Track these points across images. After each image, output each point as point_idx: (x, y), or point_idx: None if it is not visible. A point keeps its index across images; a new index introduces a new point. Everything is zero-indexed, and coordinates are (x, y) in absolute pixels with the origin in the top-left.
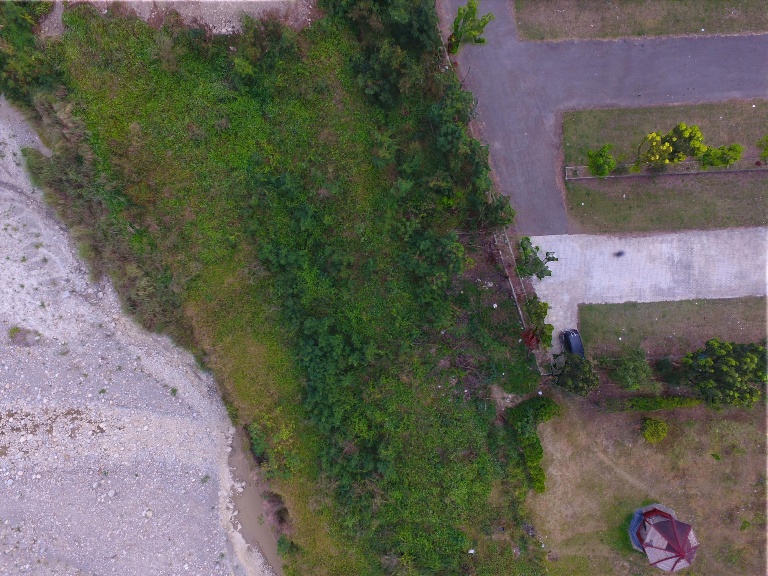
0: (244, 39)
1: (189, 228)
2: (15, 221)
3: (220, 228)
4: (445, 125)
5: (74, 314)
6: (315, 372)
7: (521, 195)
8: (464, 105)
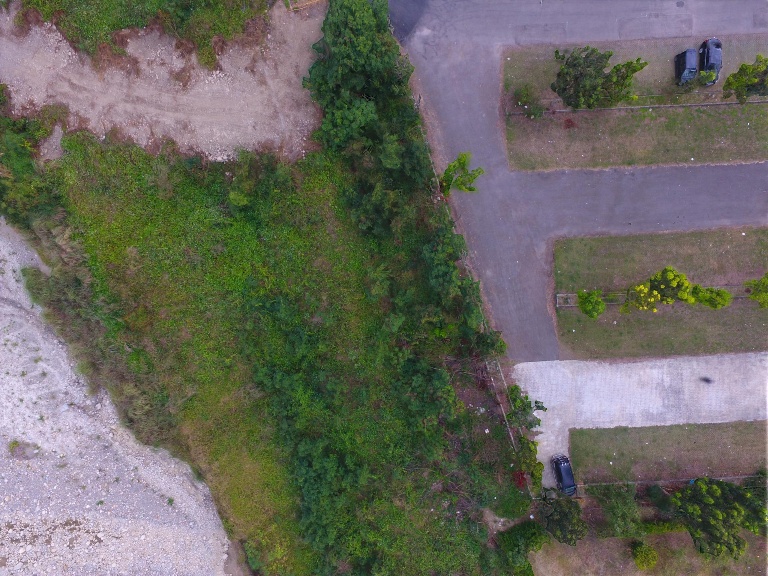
0: (239, 166)
1: (185, 349)
2: (15, 336)
3: (216, 348)
4: (436, 268)
5: (72, 427)
6: (309, 493)
7: (513, 322)
8: (455, 249)
